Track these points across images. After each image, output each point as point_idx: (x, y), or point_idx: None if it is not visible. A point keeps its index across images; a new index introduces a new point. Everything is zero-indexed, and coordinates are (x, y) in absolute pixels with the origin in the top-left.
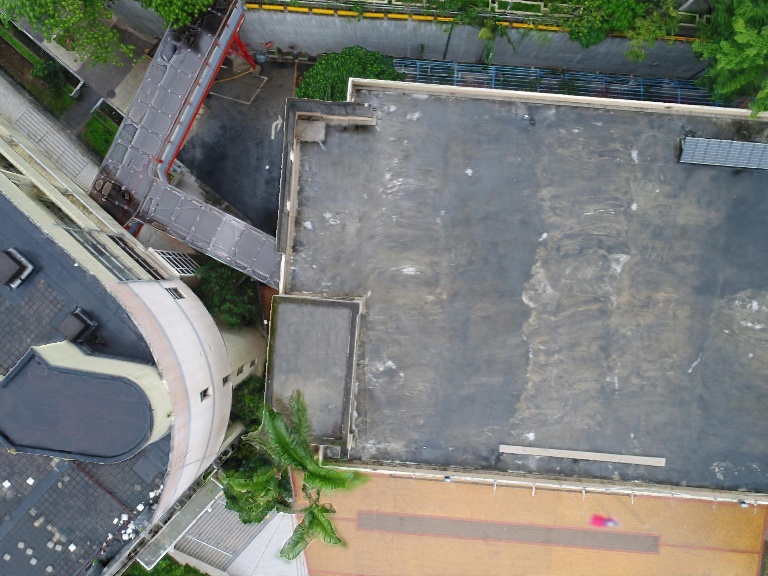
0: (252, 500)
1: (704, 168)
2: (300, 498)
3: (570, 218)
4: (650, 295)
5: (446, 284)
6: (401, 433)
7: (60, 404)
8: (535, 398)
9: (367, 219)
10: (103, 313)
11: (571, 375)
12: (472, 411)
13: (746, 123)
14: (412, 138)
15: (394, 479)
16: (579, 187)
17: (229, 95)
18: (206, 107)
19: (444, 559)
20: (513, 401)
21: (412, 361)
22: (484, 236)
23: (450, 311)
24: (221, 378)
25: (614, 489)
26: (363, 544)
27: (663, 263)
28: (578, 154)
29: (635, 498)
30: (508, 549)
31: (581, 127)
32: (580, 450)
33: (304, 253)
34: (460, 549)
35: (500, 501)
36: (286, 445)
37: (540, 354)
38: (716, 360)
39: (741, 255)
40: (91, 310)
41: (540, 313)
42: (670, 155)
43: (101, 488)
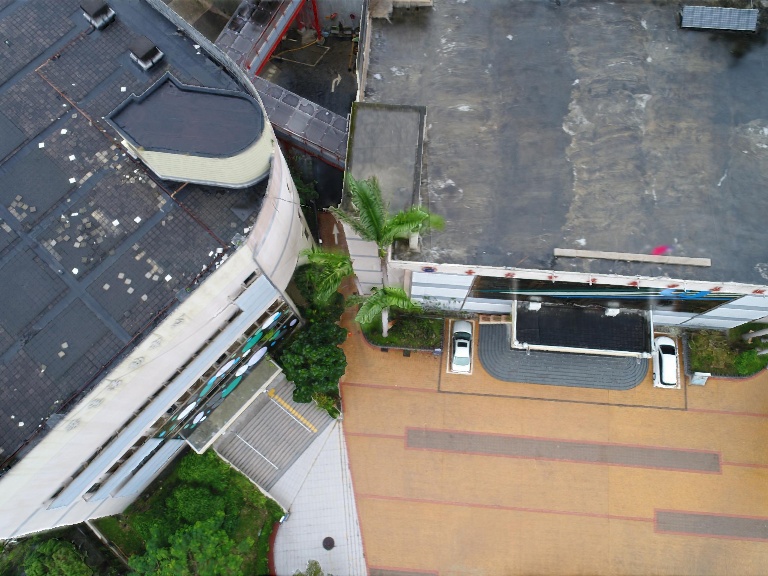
0: (329, 272)
1: (702, 32)
2: (348, 414)
3: (597, 68)
4: (673, 124)
5: (496, 118)
6: (462, 240)
7: (185, 115)
8: (582, 209)
9: (427, 71)
10: (217, 87)
11: (613, 189)
12: (526, 221)
13: (730, 1)
14: (462, 15)
15: (442, 394)
16: (601, 46)
17: (298, 60)
18: (278, 69)
19: (497, 480)
20: (563, 211)
21: (469, 179)
22: (526, 82)
23: (501, 139)
24: (297, 205)
25: (666, 278)
26: (412, 464)
27: (680, 100)
28: (598, 24)
29: (687, 412)
30: (563, 469)
31: (598, 6)
32: (629, 253)
33: (374, 97)
34: (513, 469)
35: (550, 416)
36: (366, 201)
37: (583, 172)
38: (741, 175)
39: (746, 94)
40: (207, 86)
41: (579, 139)
42: (673, 23)
43: (201, 224)
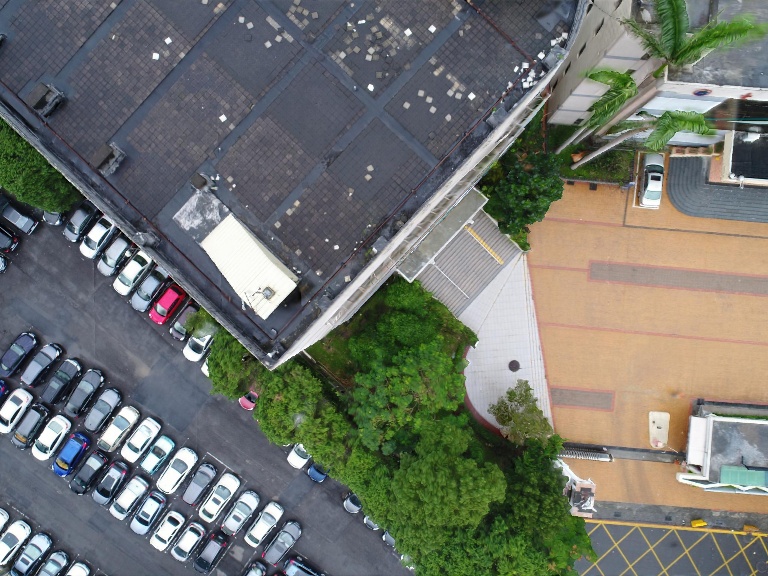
0: (616, 93)
1: None
2: (532, 247)
3: None
4: None
5: None
6: (738, 59)
7: None
8: None
9: None
10: None
11: None
12: None
13: None
14: None
15: (627, 228)
16: None
17: None
18: None
19: (676, 312)
20: None
21: None
22: None
23: None
24: None
25: None
26: (594, 295)
27: None
28: None
29: None
30: (742, 302)
31: None
32: None
33: None
34: (693, 301)
35: (735, 251)
36: None
37: None
38: None
39: None
40: None
41: None
42: None
43: (503, 35)
